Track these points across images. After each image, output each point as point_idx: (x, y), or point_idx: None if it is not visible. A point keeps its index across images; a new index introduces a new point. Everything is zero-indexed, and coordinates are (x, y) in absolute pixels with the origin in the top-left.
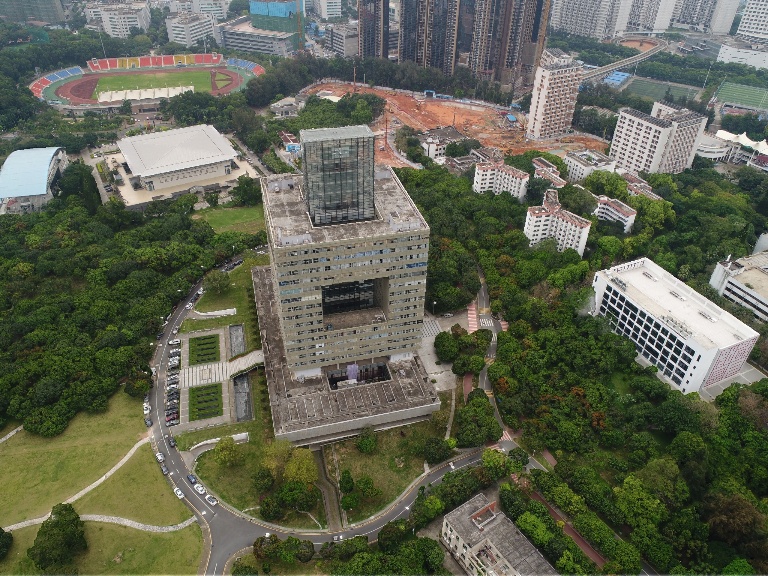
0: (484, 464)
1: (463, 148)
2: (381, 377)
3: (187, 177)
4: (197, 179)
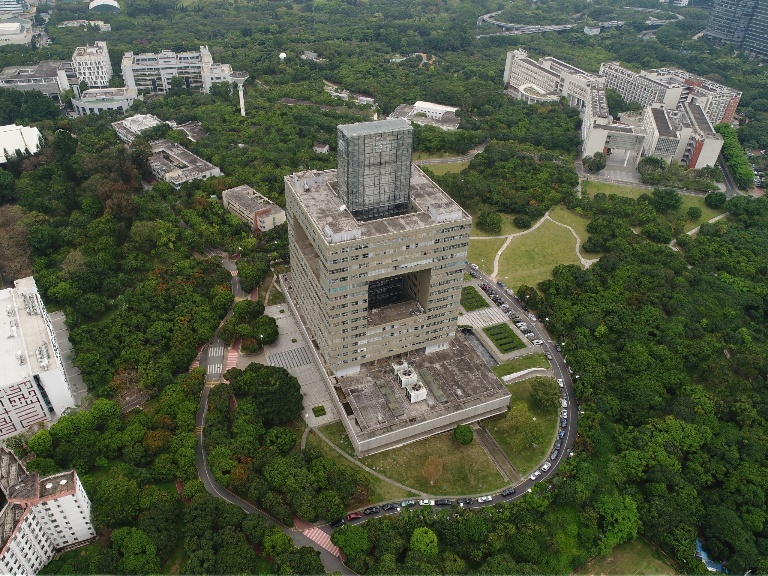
0: None
1: None
2: None
3: None
4: None
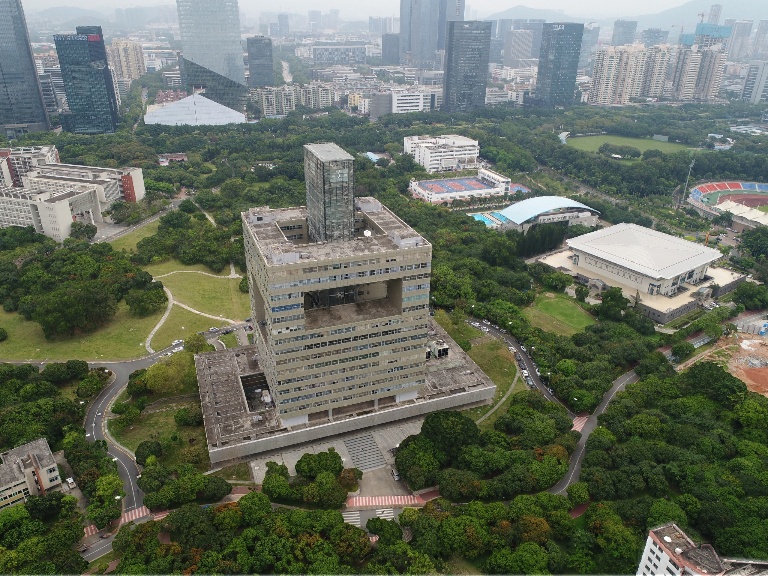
0: None
1: None
2: None
3: (610, 271)
4: (618, 279)
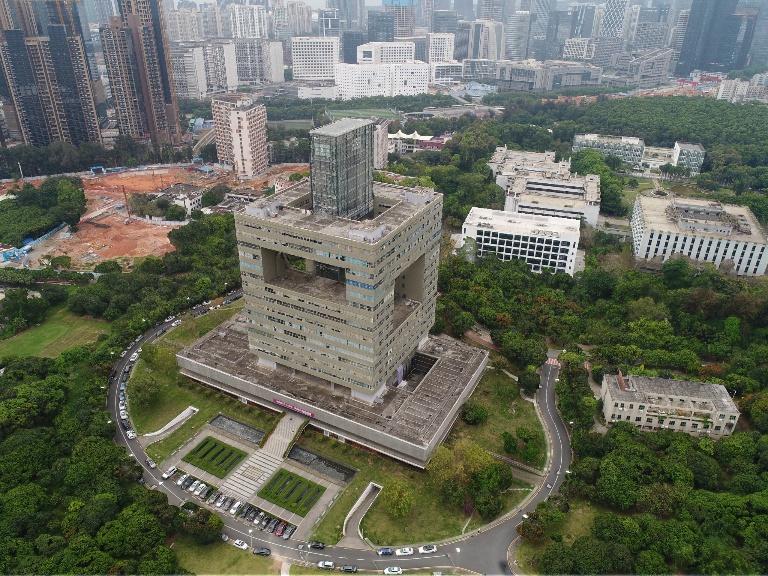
0: (572, 363)
1: (216, 195)
2: (413, 370)
3: None
4: None
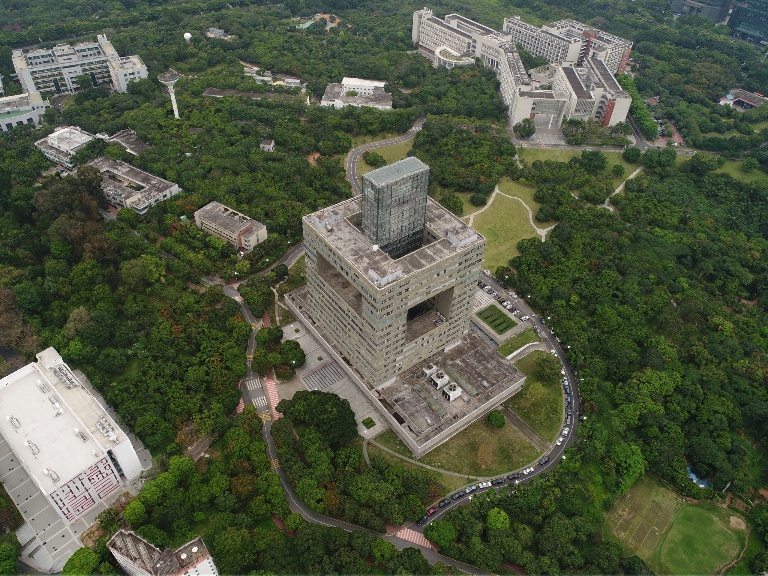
0: None
1: None
2: None
3: None
4: None
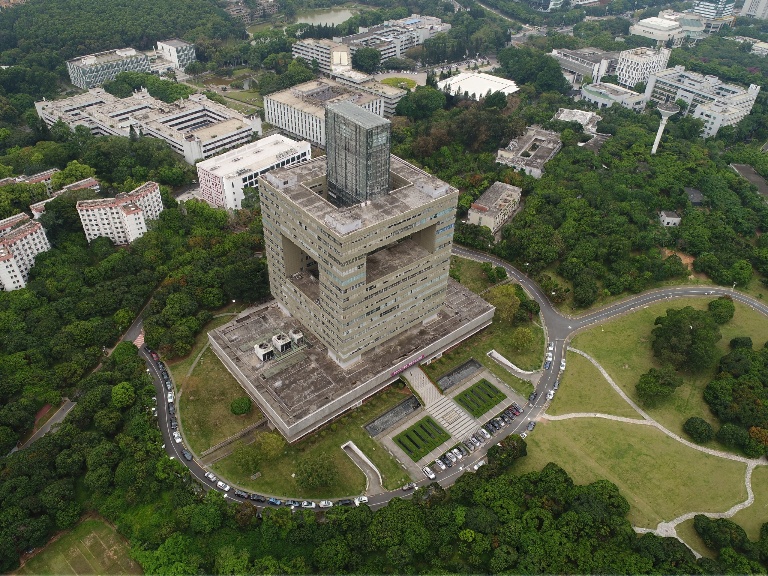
0: None
1: None
2: None
3: None
4: None
